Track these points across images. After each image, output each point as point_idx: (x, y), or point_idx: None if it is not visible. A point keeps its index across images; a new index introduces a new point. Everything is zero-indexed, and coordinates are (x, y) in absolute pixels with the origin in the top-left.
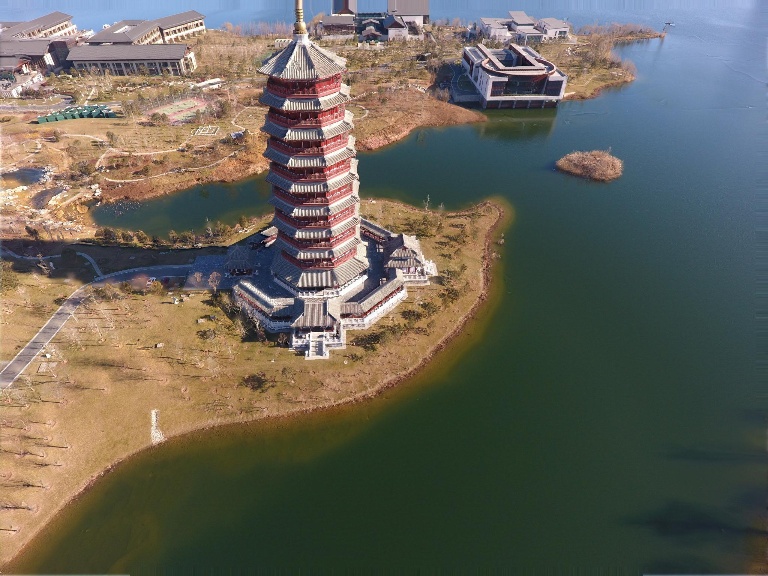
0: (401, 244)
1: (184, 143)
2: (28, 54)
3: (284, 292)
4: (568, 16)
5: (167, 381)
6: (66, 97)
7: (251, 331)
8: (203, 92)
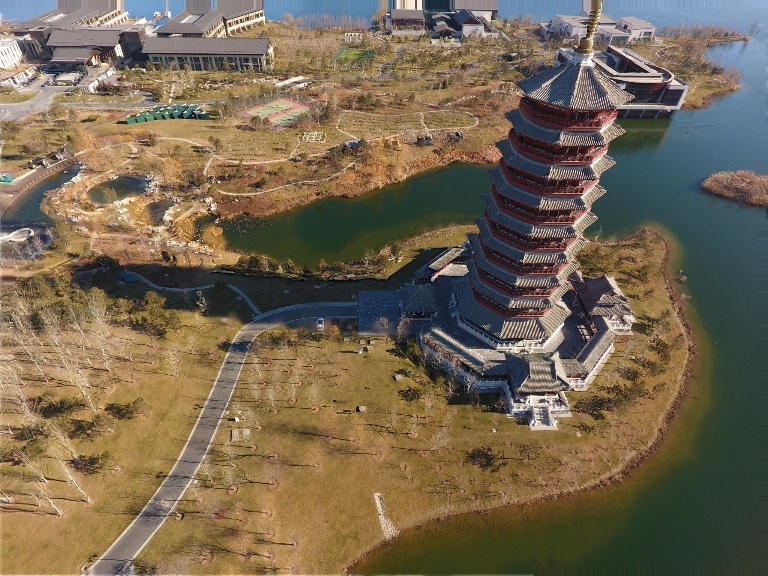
0: (607, 288)
1: (294, 151)
2: (98, 45)
3: (476, 341)
4: (650, 16)
5: (382, 455)
6: (146, 94)
7: (458, 392)
8: (293, 92)
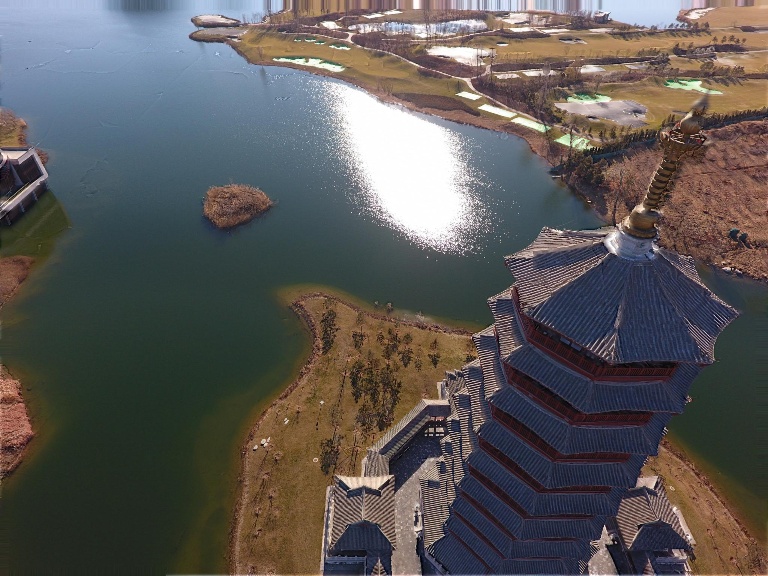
0: None
1: None
2: None
3: None
4: None
5: None
6: None
7: None
8: None
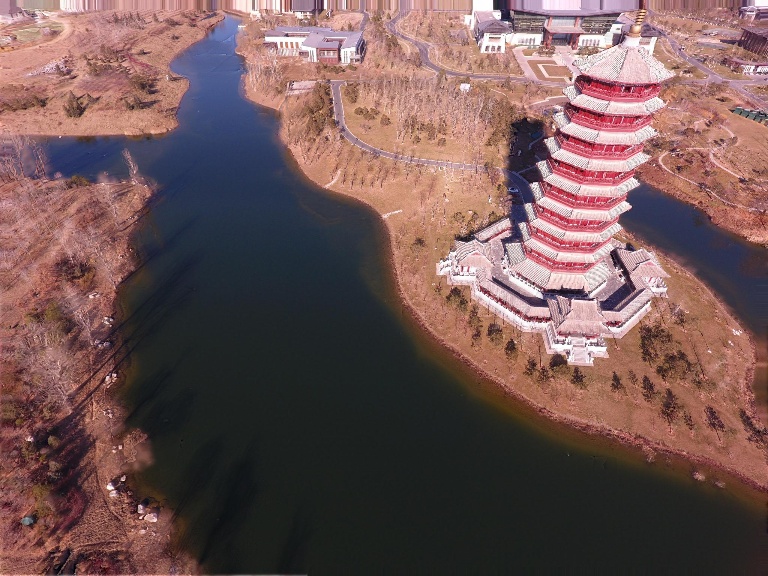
0: None
1: (761, 179)
2: None
3: None
4: None
5: (421, 209)
6: None
7: None
8: None
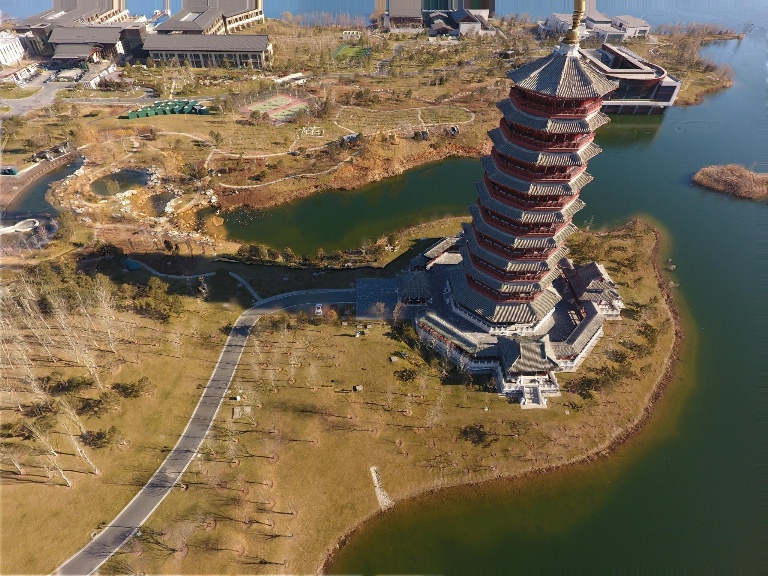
0: (597, 274)
1: (293, 145)
2: (100, 42)
3: (469, 325)
4: (645, 14)
5: (378, 432)
6: (147, 90)
7: (452, 372)
8: (292, 88)
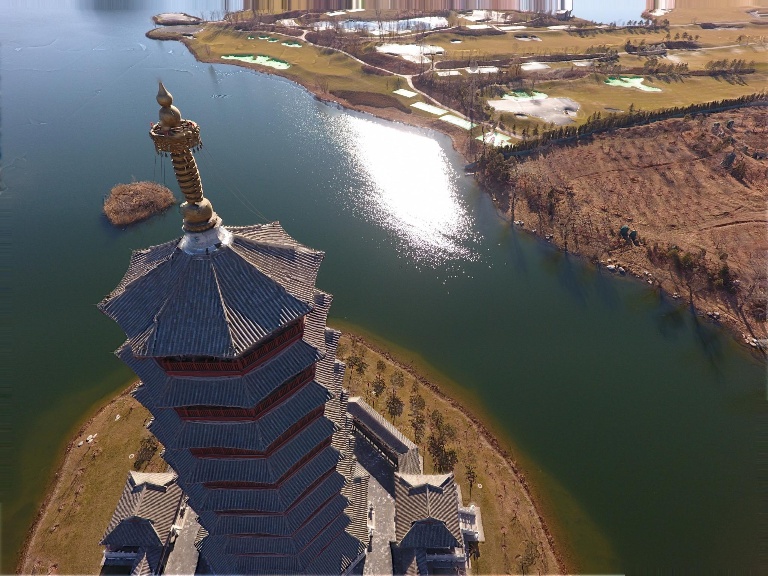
0: None
1: None
2: None
3: None
4: None
5: None
6: None
7: None
8: None
